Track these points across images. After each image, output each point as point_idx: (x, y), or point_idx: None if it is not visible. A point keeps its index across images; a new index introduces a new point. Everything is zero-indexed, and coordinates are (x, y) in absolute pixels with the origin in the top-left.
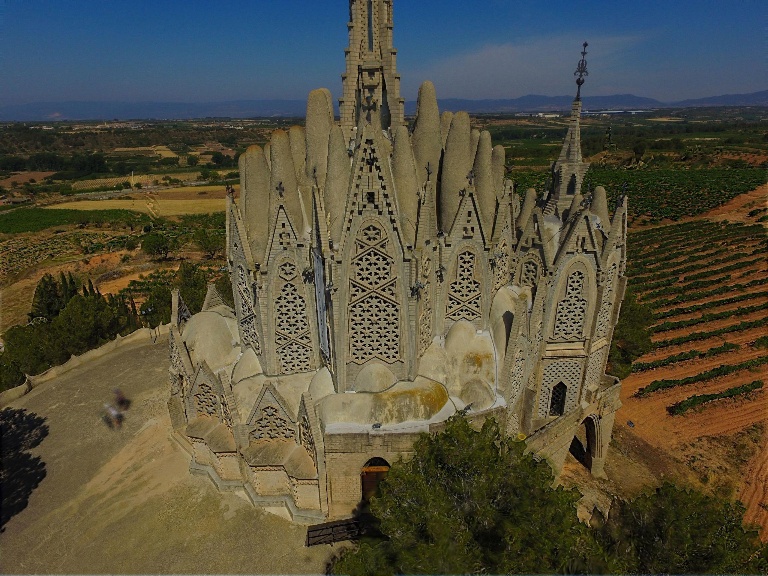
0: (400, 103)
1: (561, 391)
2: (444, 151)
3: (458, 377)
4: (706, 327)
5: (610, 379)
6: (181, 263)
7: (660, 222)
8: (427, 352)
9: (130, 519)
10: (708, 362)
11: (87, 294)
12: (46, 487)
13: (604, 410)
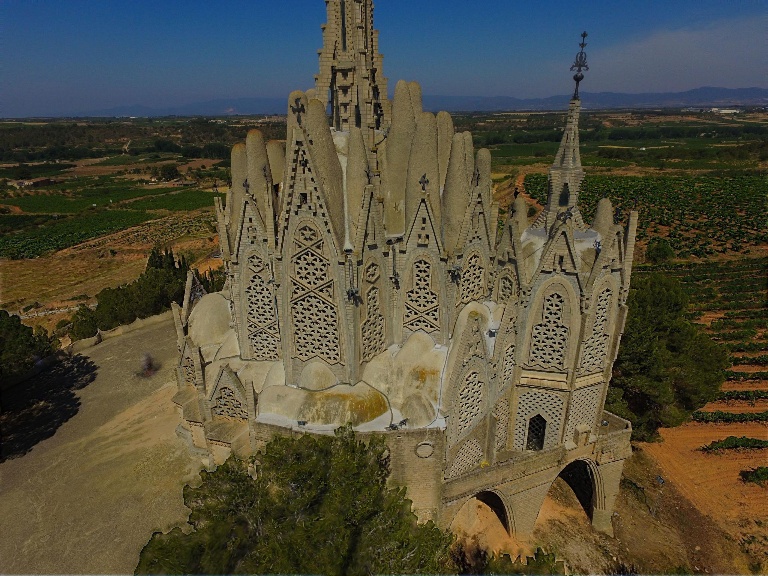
0: (367, 104)
1: (541, 425)
2: None
3: (402, 389)
4: None
5: (621, 422)
6: None
7: None
8: (375, 359)
9: (115, 463)
10: None
11: (181, 267)
12: (73, 423)
13: (602, 456)
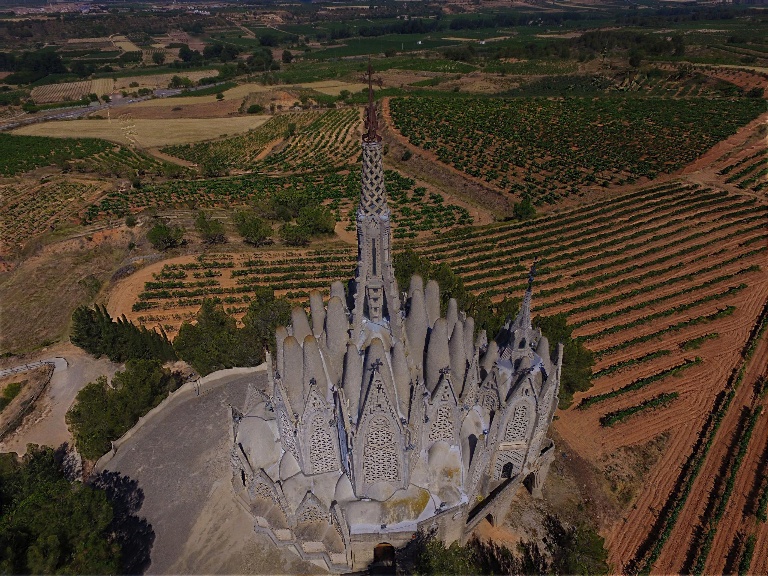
0: (397, 313)
1: (509, 465)
2: (429, 307)
3: (437, 482)
4: (650, 326)
5: (548, 441)
6: (203, 303)
7: (636, 181)
8: (416, 468)
9: (223, 572)
10: (642, 367)
11: (122, 324)
12: (159, 547)
13: (541, 467)
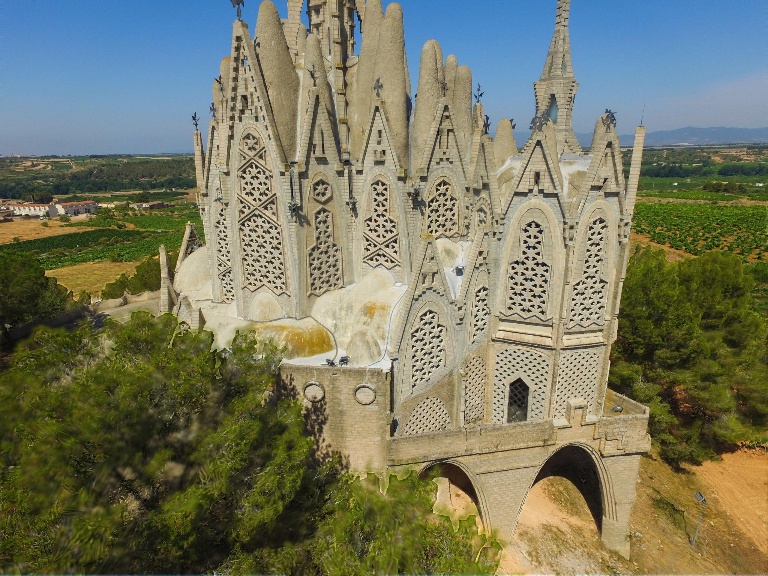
0: (333, 18)
1: (525, 393)
2: None
3: (351, 327)
4: None
5: (638, 408)
6: None
7: None
8: (327, 294)
9: None
10: None
11: None
12: None
13: (606, 444)
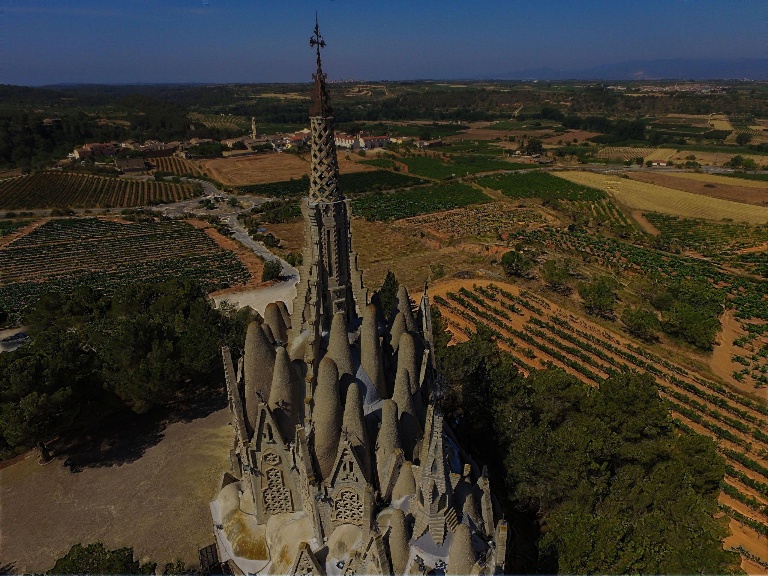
0: (310, 324)
1: None
2: None
3: None
4: None
5: None
6: None
7: None
8: (277, 515)
9: (205, 459)
10: None
11: None
12: (218, 414)
13: None
